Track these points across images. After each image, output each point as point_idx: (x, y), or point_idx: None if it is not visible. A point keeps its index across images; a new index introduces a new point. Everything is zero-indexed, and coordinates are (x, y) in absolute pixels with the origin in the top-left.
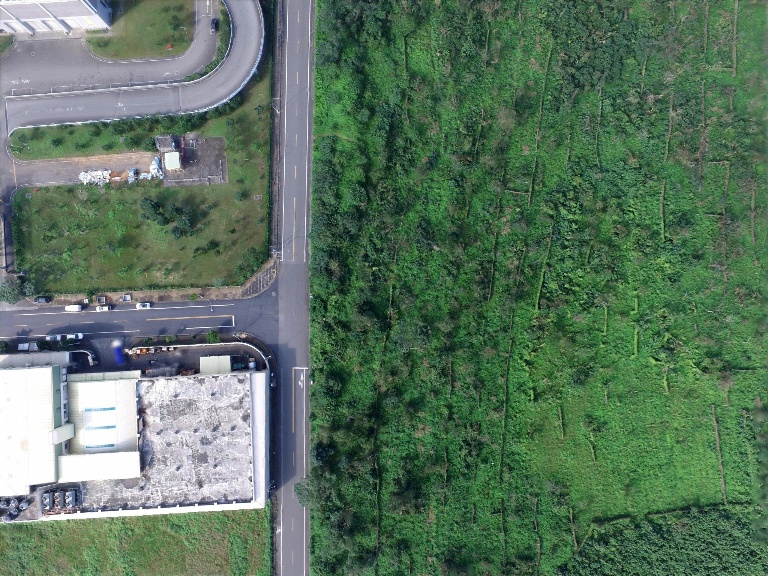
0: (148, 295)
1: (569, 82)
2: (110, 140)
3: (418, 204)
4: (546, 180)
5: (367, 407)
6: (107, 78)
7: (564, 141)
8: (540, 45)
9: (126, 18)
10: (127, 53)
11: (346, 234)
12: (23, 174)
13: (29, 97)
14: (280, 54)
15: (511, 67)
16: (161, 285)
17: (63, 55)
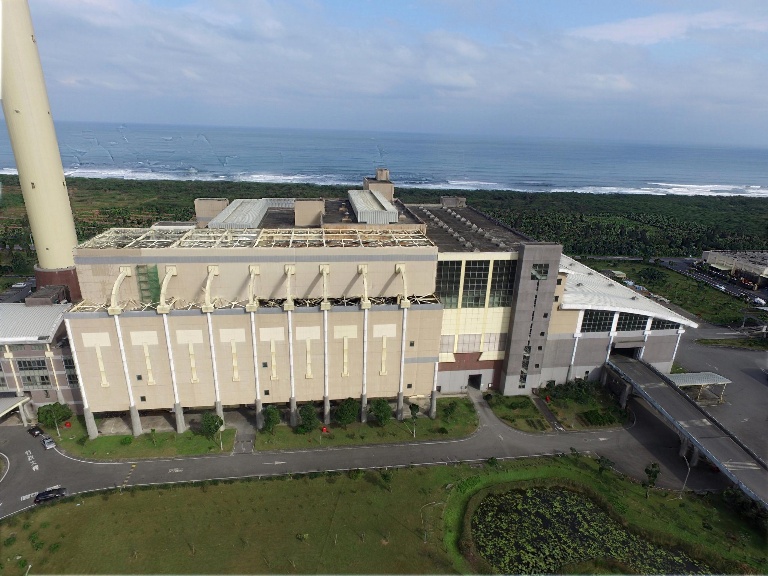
0: None
1: None
2: None
3: None
4: None
5: (683, 240)
6: None
7: None
8: None
9: None
10: None
11: None
12: None
13: None
14: None
15: None
16: None
17: None
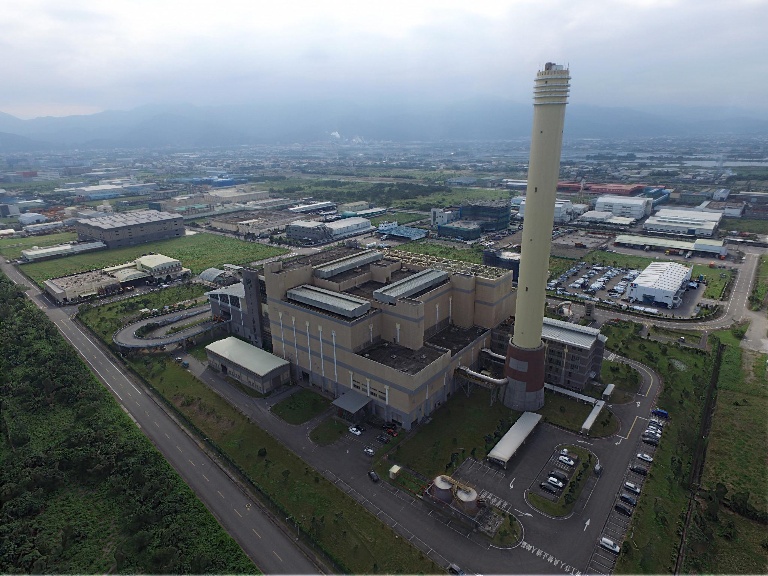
0: None
1: None
2: None
3: None
4: None
5: None
6: None
7: None
8: None
9: None
10: None
11: None
12: None
13: None
14: None
15: None
16: None
17: None
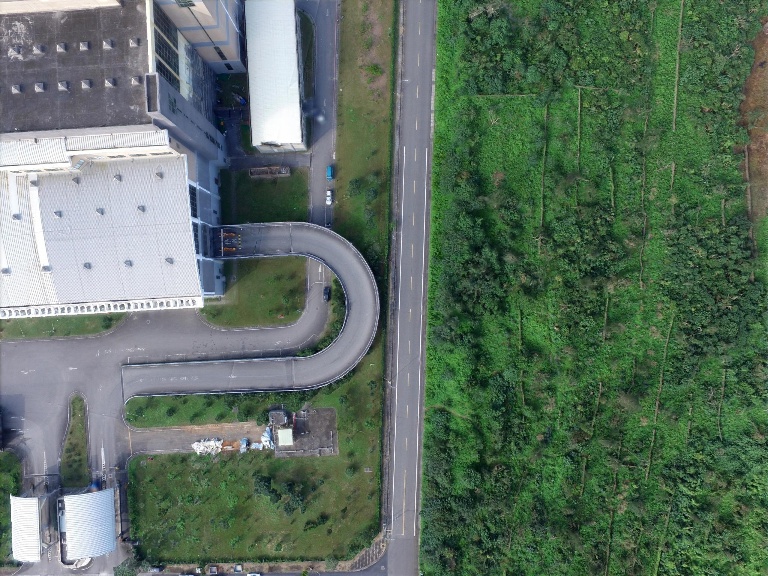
0: (258, 565)
1: (692, 353)
2: (222, 409)
3: (532, 483)
4: (664, 452)
5: None
6: (220, 346)
7: (685, 413)
8: (661, 312)
9: (239, 286)
10: (240, 321)
11: (461, 522)
12: (138, 441)
13: (144, 366)
14: (392, 323)
15: (630, 335)
16: (271, 556)
17: (177, 323)
